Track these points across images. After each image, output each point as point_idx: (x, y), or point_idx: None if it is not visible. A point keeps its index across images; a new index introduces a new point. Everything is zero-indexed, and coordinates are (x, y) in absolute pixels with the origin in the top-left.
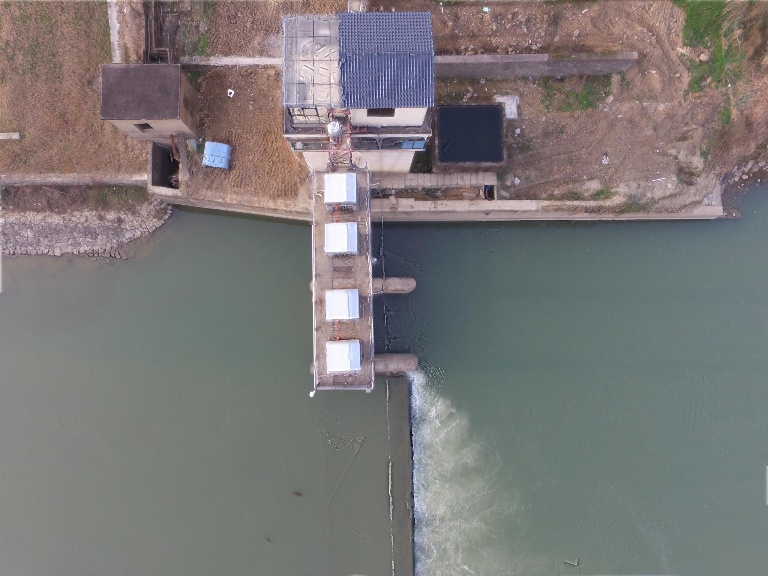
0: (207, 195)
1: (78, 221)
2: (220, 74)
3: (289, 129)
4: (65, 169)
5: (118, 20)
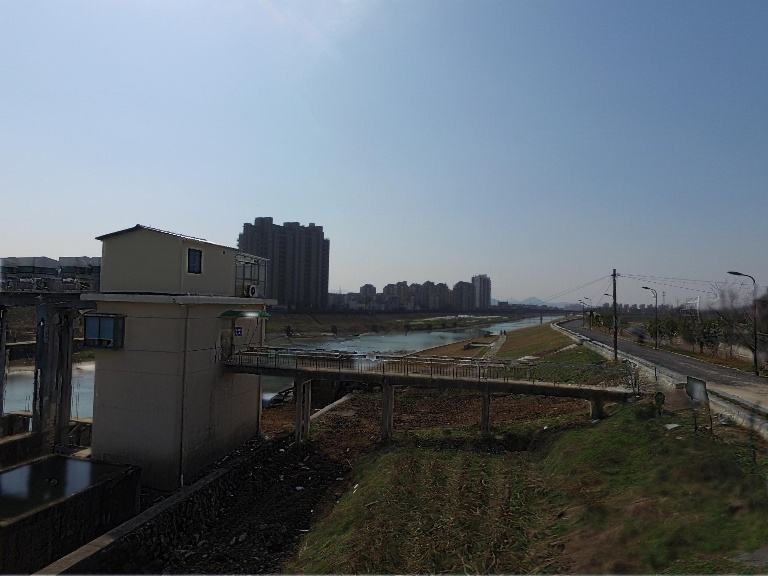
0: None
1: None
2: None
3: None
4: None
5: None
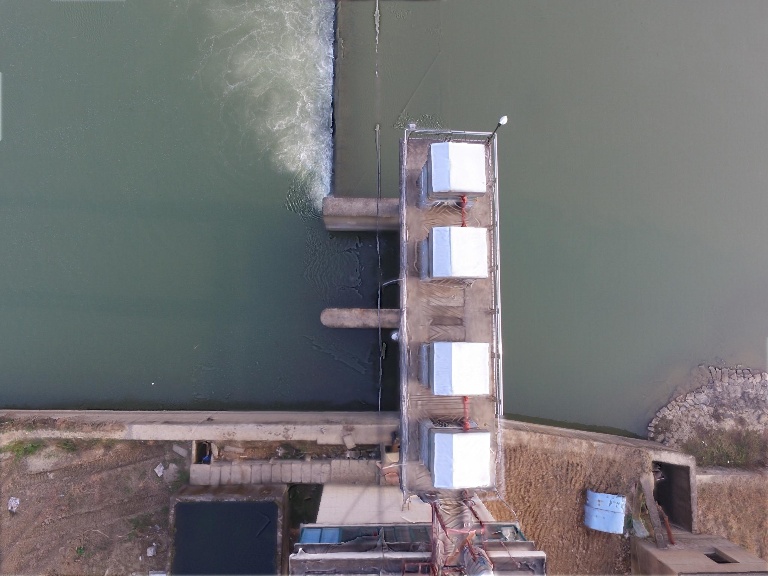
0: (614, 452)
1: None
2: None
3: (536, 566)
4: None
5: None
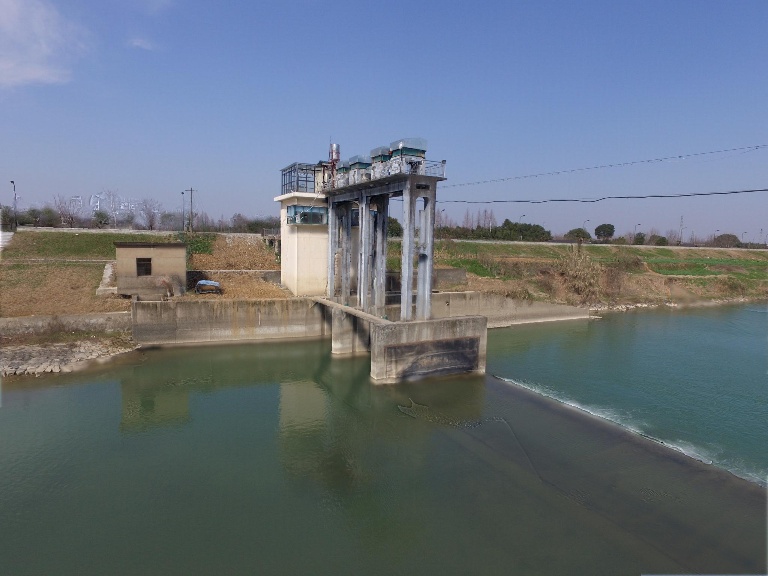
0: None
1: (8, 350)
2: (203, 278)
3: None
4: (19, 315)
5: (112, 272)
